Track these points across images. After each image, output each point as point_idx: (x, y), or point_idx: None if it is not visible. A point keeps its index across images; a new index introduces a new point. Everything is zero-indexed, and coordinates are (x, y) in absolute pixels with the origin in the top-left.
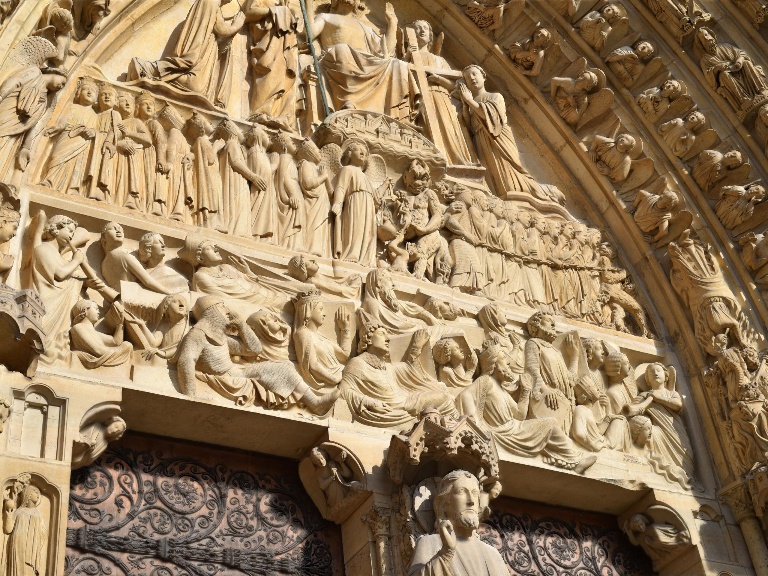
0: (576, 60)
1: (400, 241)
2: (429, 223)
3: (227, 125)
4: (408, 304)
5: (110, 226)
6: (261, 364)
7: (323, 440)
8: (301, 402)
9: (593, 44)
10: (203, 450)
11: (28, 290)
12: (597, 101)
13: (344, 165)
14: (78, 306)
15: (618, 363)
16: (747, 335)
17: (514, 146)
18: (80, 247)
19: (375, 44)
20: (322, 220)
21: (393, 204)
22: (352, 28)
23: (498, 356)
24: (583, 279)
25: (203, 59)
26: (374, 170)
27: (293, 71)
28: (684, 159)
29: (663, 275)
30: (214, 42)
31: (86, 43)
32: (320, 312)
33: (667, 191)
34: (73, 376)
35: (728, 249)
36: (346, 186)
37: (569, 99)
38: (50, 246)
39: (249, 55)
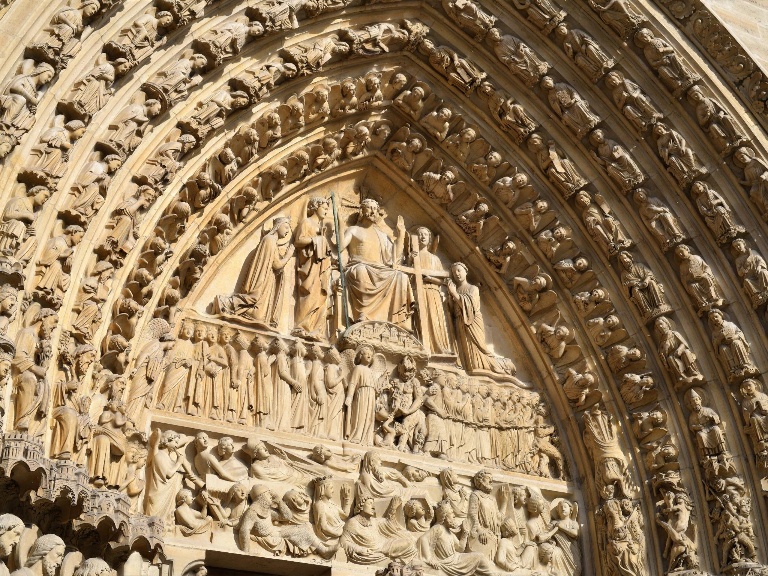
0: (533, 265)
1: (391, 422)
2: (412, 406)
3: (278, 344)
4: (392, 472)
5: (200, 436)
6: (291, 529)
7: (328, 575)
8: (315, 551)
9: (546, 253)
10: (254, 575)
11: (155, 518)
12: (545, 297)
13: (356, 364)
14: (180, 495)
15: (535, 505)
16: (629, 486)
17: (482, 331)
18: (181, 447)
19: (387, 255)
20: (338, 411)
21: (389, 390)
22: (371, 241)
23: (448, 512)
24: (521, 436)
25: (264, 294)
26: (378, 364)
27: (326, 291)
28: (603, 346)
29: (579, 433)
30: (272, 274)
31: (187, 299)
32: (331, 490)
33: (586, 374)
34: (177, 544)
35: (625, 419)
36: (356, 382)
37: (525, 295)
38: (164, 454)
39: (296, 274)
